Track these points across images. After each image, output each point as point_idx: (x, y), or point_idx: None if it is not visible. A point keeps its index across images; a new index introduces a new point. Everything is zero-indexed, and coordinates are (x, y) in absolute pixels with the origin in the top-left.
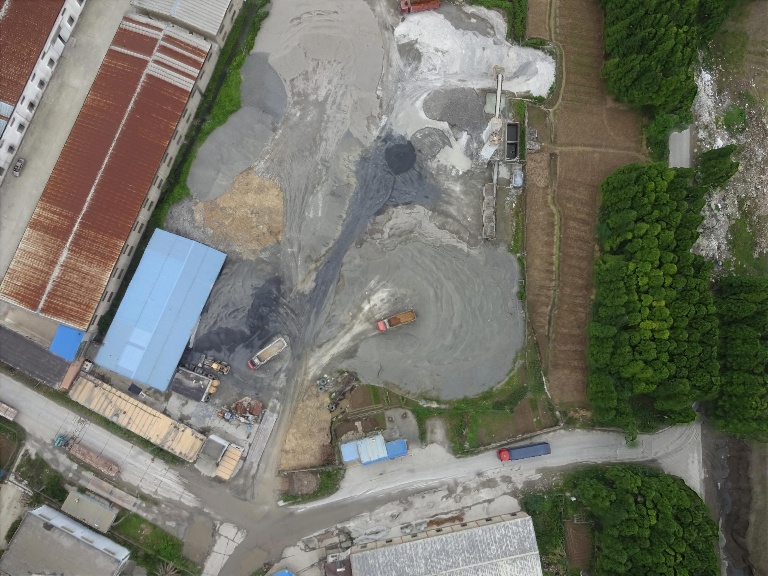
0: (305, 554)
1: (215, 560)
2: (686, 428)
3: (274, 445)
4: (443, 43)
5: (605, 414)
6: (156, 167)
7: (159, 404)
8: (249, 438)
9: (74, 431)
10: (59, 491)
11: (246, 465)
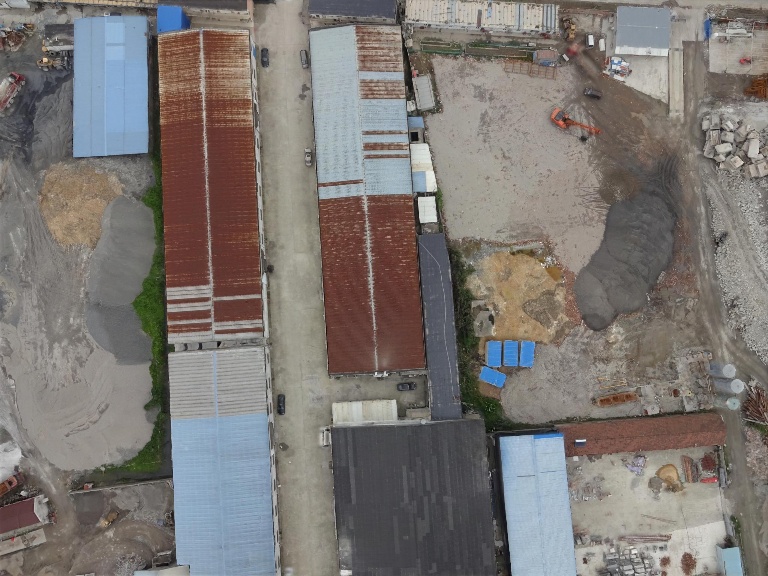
0: None
1: None
2: None
3: None
4: None
5: None
6: (165, 203)
7: (89, 13)
8: None
9: None
10: None
11: None
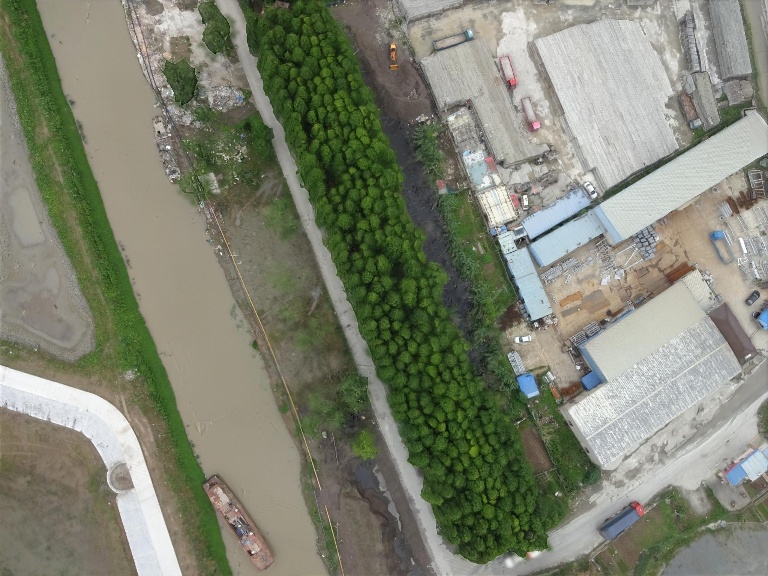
0: (759, 347)
1: None
2: None
3: None
4: None
5: None
6: None
7: None
8: None
9: None
10: None
11: None
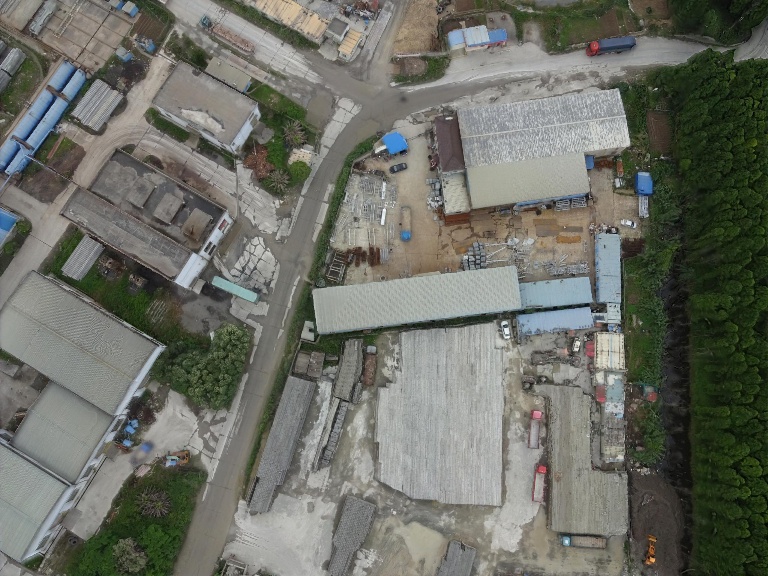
0: (413, 126)
1: (334, 127)
2: (758, 44)
3: (388, 38)
4: None
5: (687, 3)
6: None
7: None
8: (366, 31)
9: (216, 18)
10: (203, 60)
11: (363, 52)
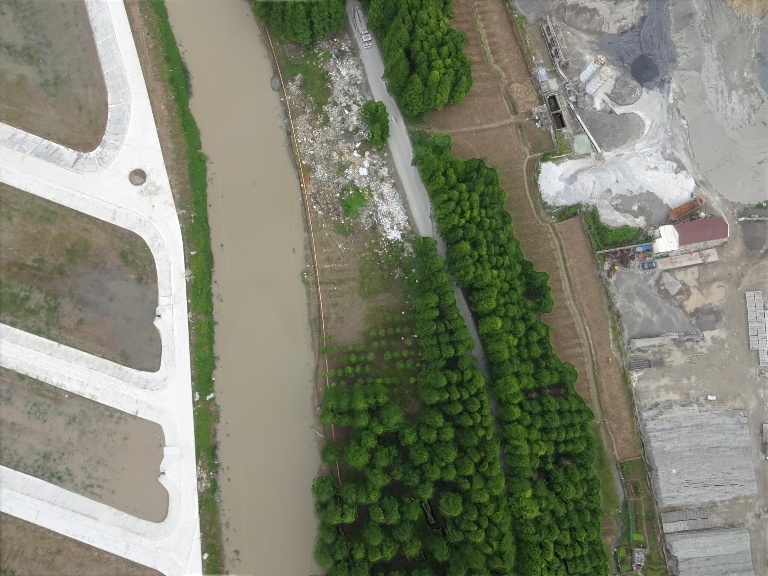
0: None
1: None
2: None
3: None
4: (654, 177)
5: None
6: None
7: None
8: None
9: None
10: None
11: None
